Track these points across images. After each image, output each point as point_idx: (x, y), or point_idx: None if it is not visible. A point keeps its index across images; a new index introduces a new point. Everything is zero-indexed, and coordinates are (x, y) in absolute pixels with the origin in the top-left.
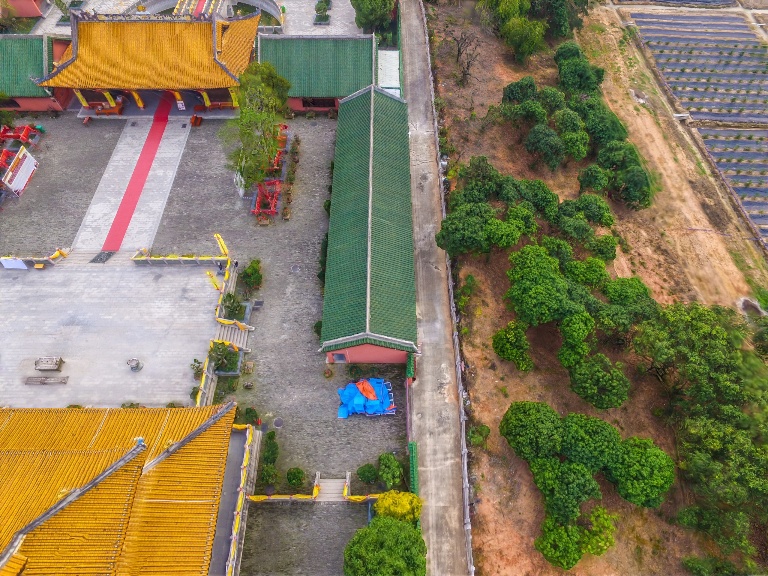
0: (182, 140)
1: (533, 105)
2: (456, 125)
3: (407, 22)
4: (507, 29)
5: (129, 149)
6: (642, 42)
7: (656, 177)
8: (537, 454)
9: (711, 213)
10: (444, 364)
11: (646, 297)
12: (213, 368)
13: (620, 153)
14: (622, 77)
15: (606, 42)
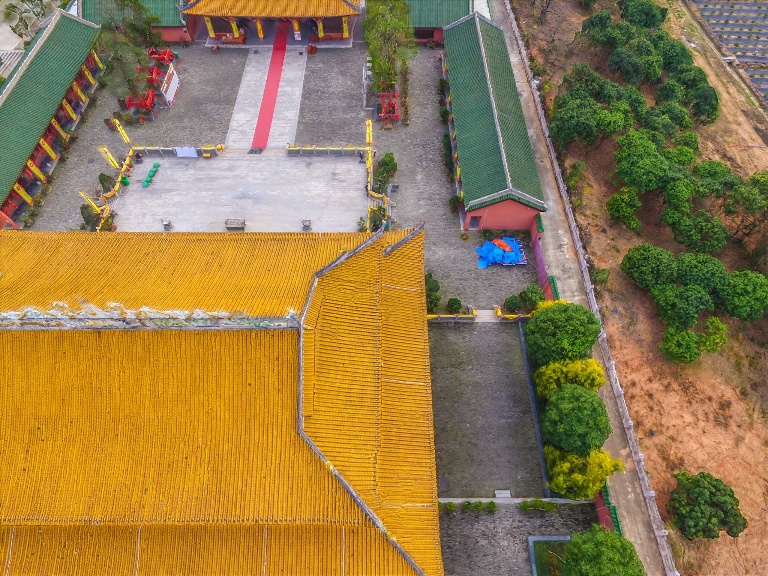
0: (302, 64)
1: (613, 32)
2: (541, 53)
3: None
4: None
5: (257, 71)
6: None
7: None
8: (657, 281)
9: (763, 135)
10: (561, 231)
11: None
12: (370, 230)
13: (691, 73)
14: (673, 26)
15: None
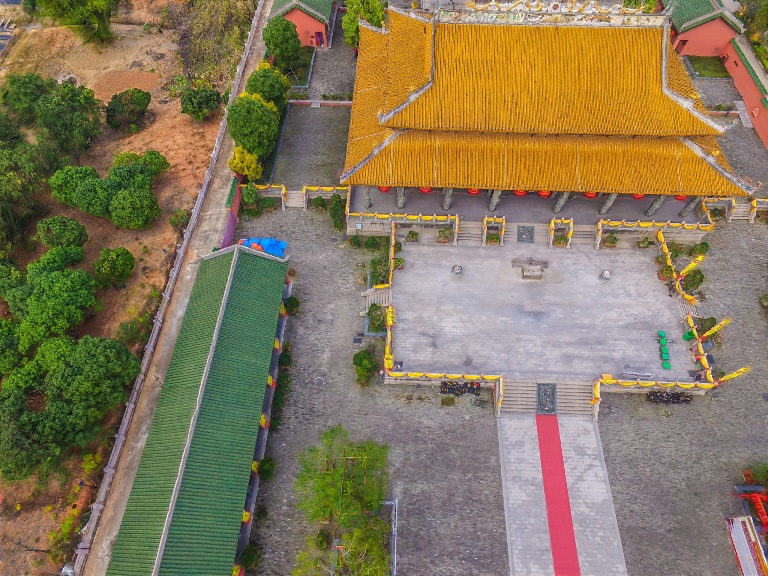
0: None
1: None
2: None
3: None
4: None
5: None
6: None
7: None
8: None
9: None
10: (188, 278)
11: None
12: None
13: None
14: None
15: None
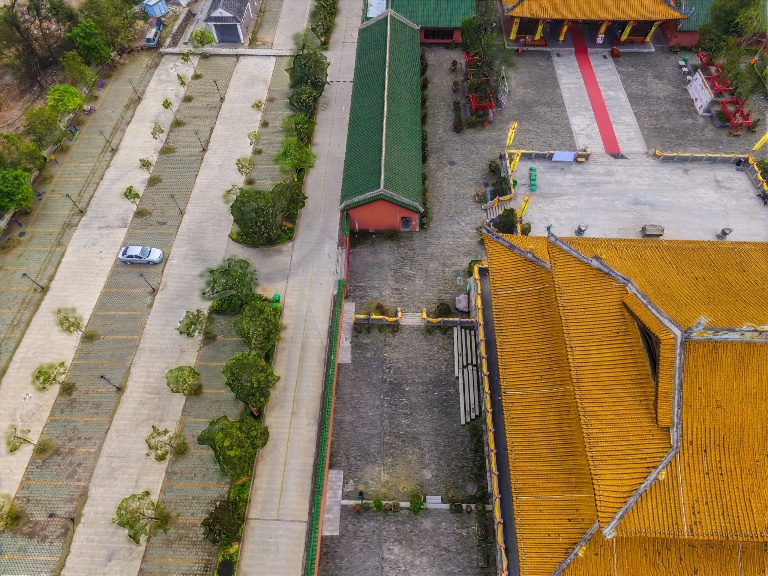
0: (612, 68)
1: None
2: None
3: None
4: None
5: (570, 74)
6: None
7: None
8: None
9: None
10: None
11: None
12: None
13: None
14: None
15: None
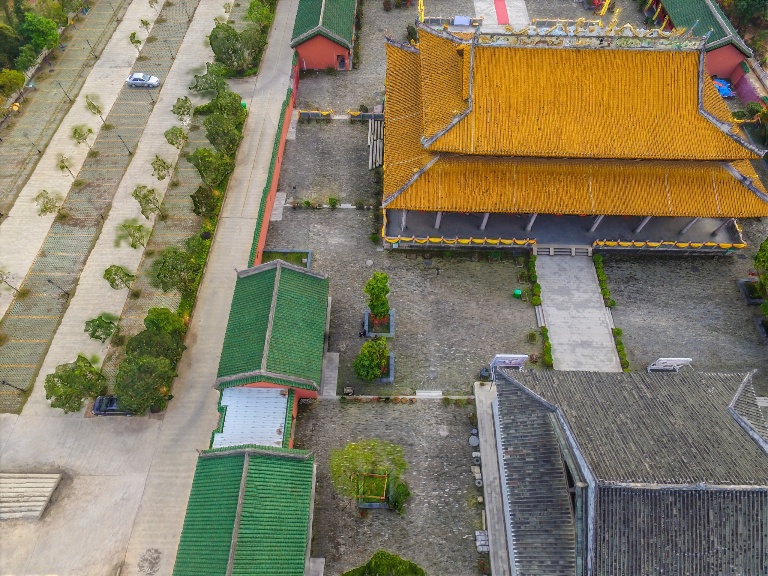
0: None
1: None
2: None
3: None
4: None
5: None
6: None
7: None
8: None
9: None
10: (752, 80)
11: None
12: None
13: None
14: None
15: None
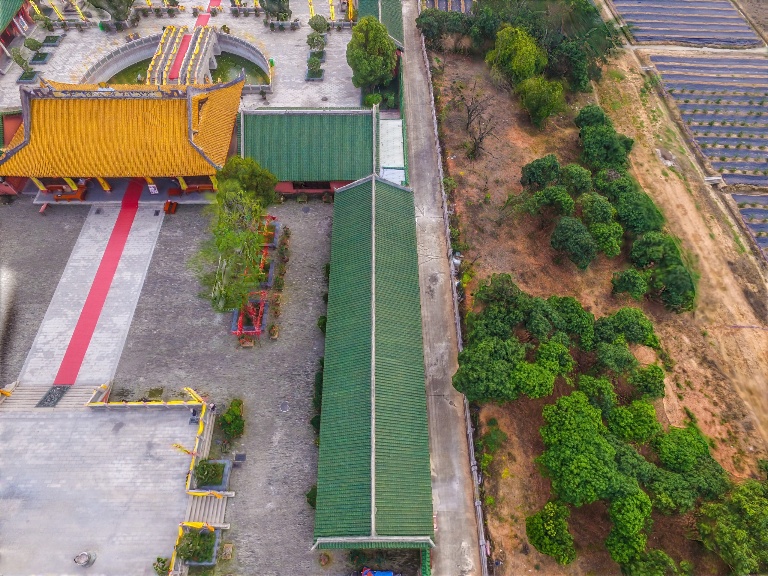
0: (154, 232)
1: (558, 193)
2: (469, 211)
3: (409, 76)
4: (522, 88)
5: (92, 244)
6: (664, 90)
7: (692, 260)
8: None
9: (755, 303)
10: (465, 542)
11: (707, 457)
12: (182, 559)
13: (659, 249)
14: (646, 134)
15: (626, 91)
